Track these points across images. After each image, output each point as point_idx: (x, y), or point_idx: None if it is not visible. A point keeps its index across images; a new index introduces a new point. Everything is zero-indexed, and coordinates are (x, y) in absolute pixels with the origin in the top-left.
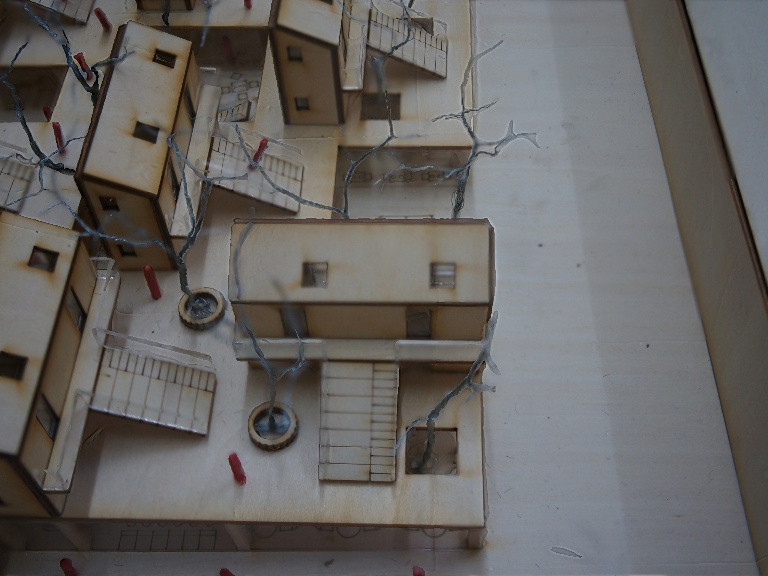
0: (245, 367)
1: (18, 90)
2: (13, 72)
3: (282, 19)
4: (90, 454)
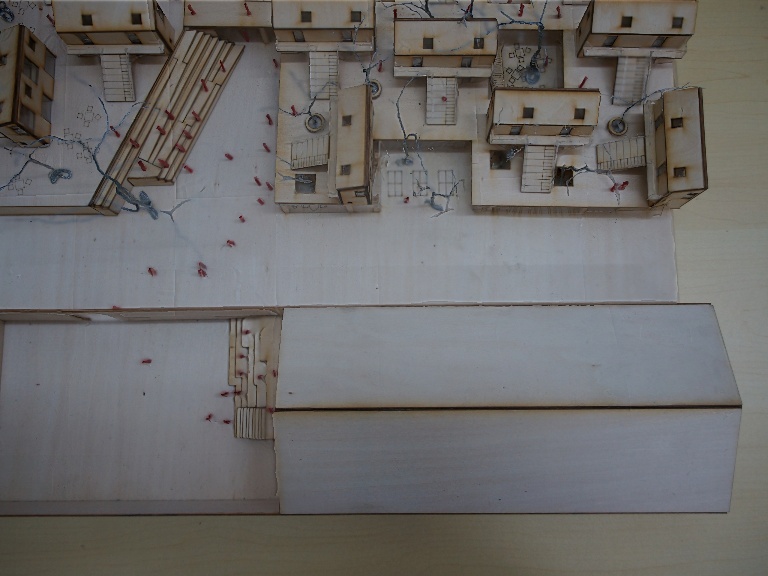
0: None
1: None
2: None
3: (499, 92)
4: (305, 58)
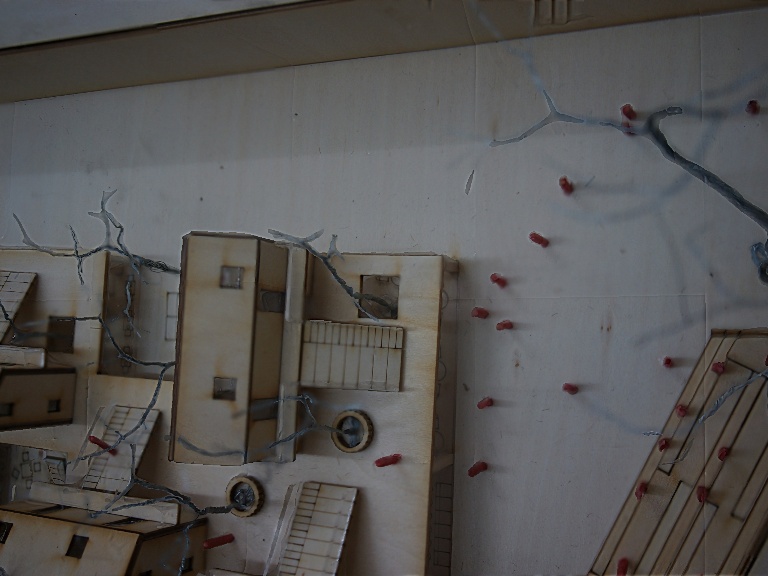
0: (299, 457)
1: None
2: None
3: None
4: None
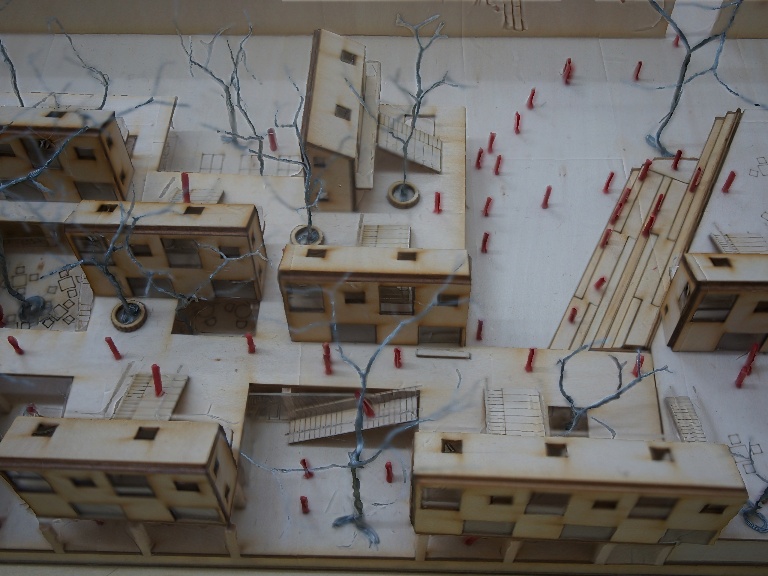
0: (356, 215)
1: None
2: None
3: (94, 126)
4: None
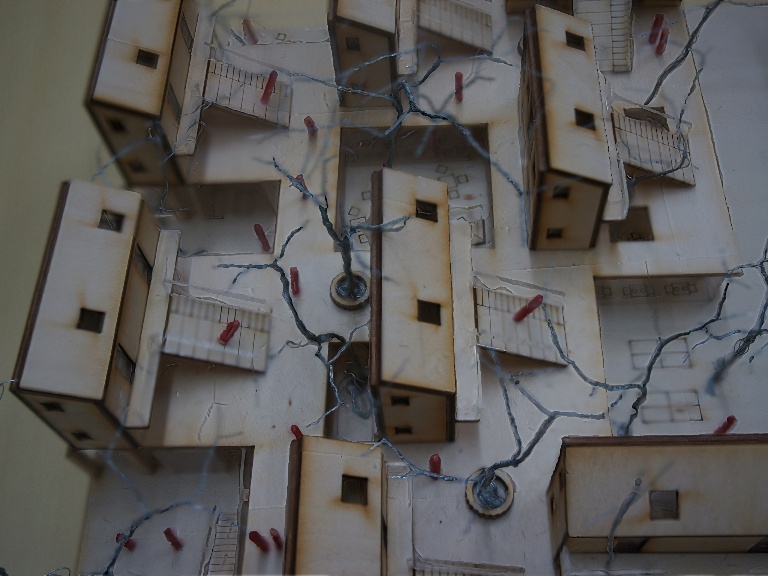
0: (550, 565)
1: (215, 195)
2: (216, 185)
3: (554, 161)
4: None
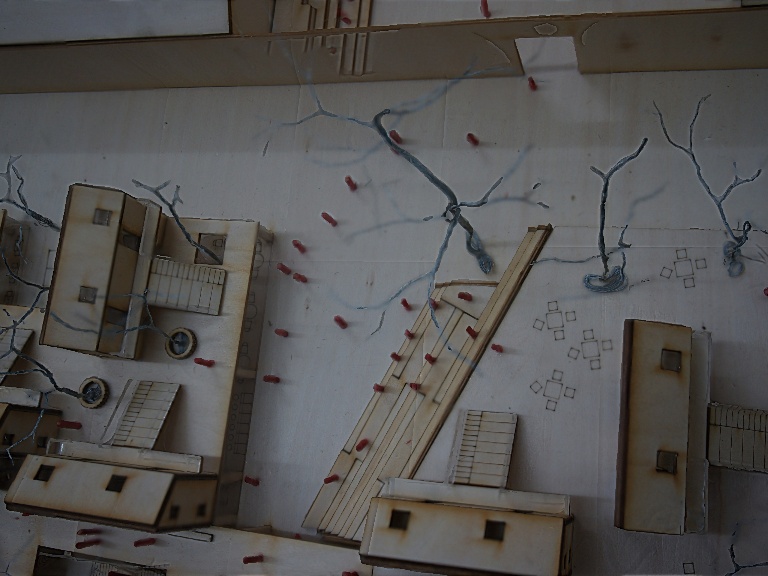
0: (139, 364)
1: None
2: None
3: None
4: None
